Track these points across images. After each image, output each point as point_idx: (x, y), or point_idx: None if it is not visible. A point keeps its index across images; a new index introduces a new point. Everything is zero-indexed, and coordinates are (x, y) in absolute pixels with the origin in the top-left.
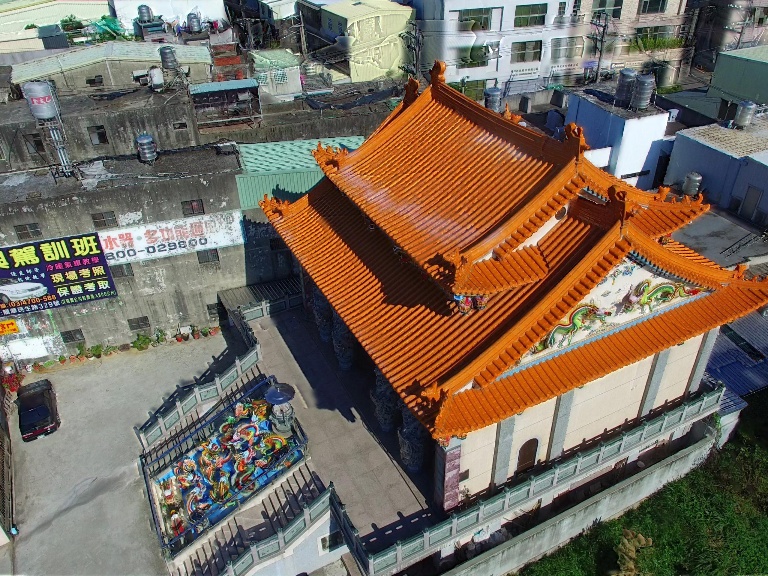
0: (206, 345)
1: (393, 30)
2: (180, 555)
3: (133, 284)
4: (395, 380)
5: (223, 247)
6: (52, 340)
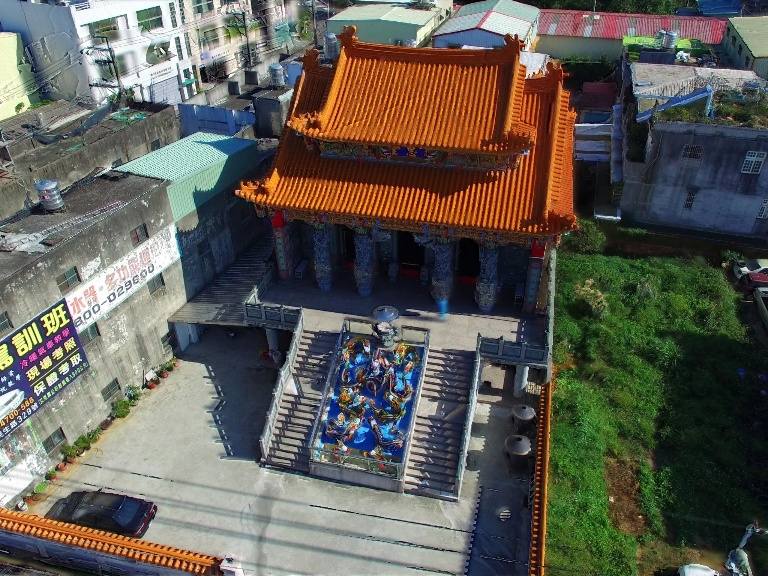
0: (184, 375)
1: (58, 51)
2: (405, 469)
3: (101, 346)
4: (509, 227)
5: (166, 269)
6: (35, 458)
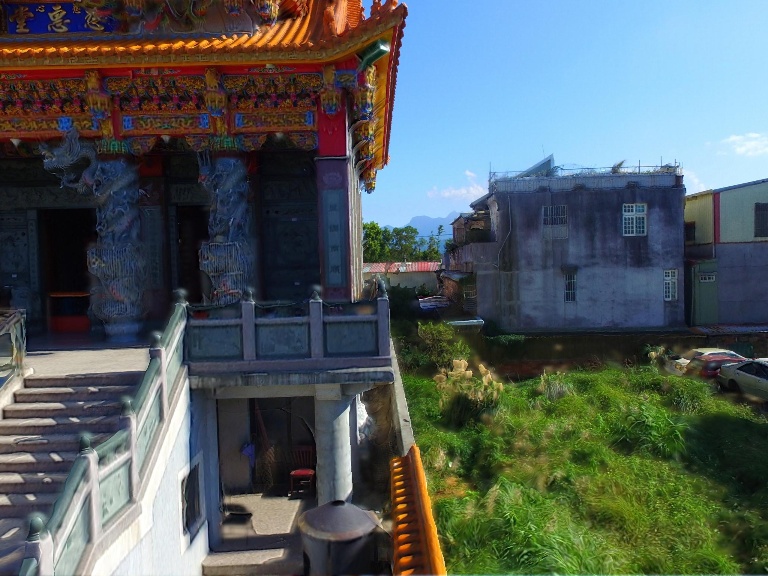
0: None
1: None
2: None
3: None
4: None
5: None
6: None
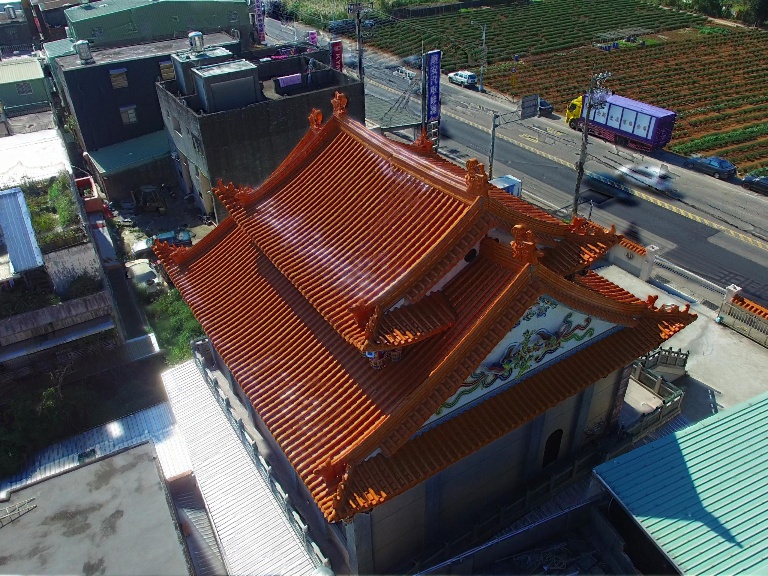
0: None
1: None
2: None
3: None
4: None
5: None
6: None
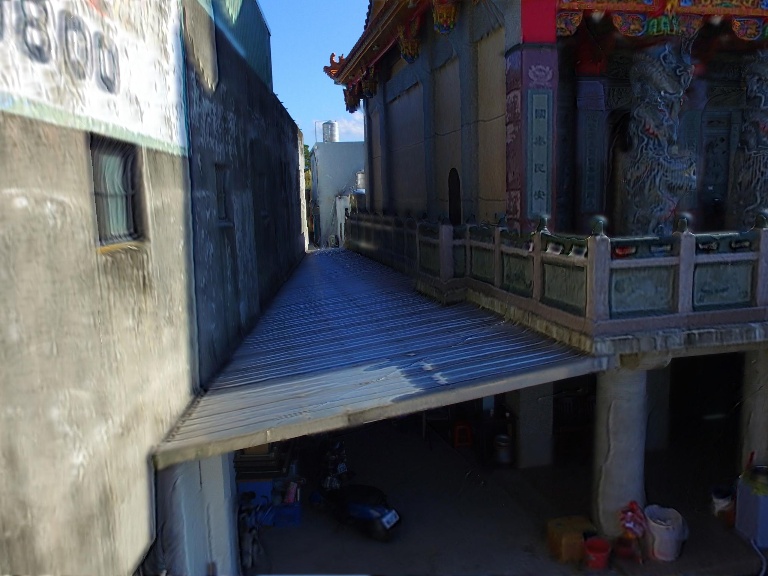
0: None
1: None
2: None
3: None
4: None
5: (152, 148)
6: None
